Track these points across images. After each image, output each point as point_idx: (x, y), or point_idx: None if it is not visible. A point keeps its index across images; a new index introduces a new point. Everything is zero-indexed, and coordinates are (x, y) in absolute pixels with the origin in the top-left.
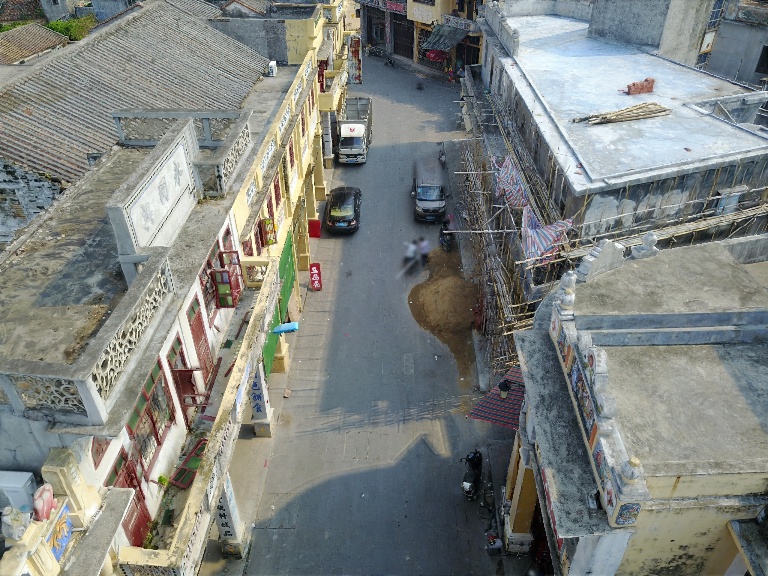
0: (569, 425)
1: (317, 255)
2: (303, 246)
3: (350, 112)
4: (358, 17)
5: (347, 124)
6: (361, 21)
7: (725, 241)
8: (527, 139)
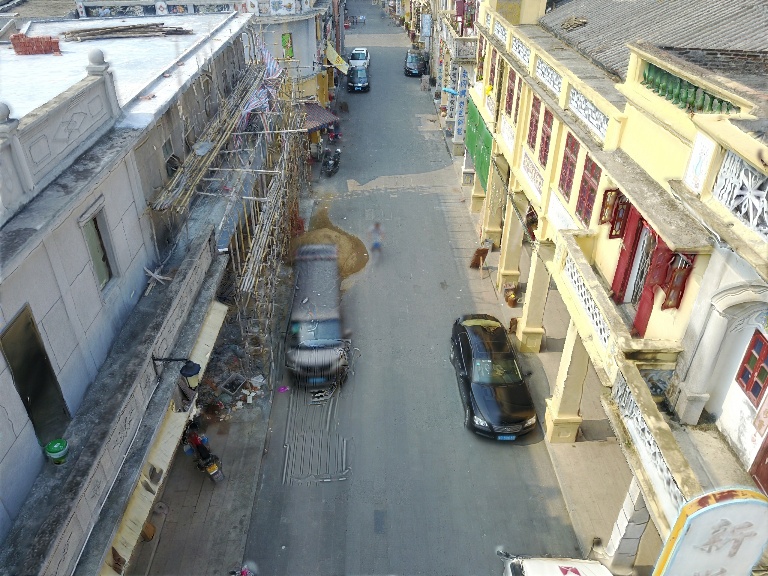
0: None
1: (498, 310)
2: None
3: None
4: None
5: None
6: None
7: None
8: None
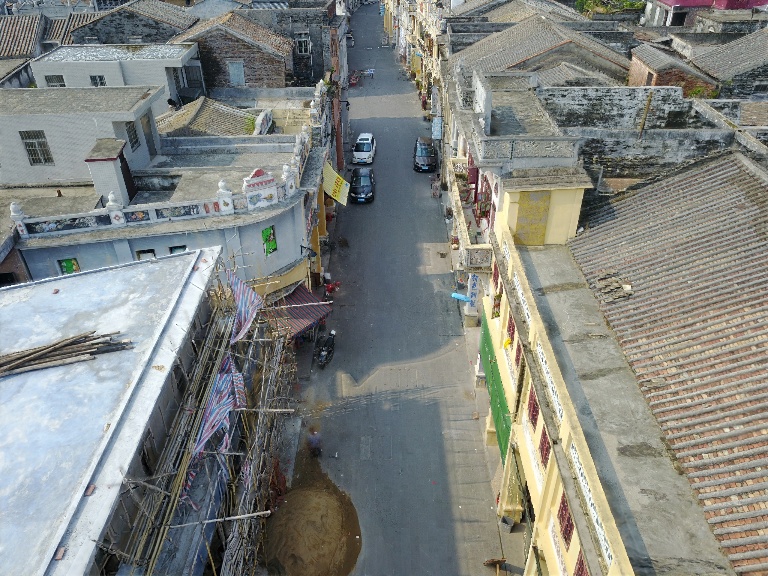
0: None
1: None
2: None
3: None
4: None
5: None
6: None
7: (164, 203)
8: None
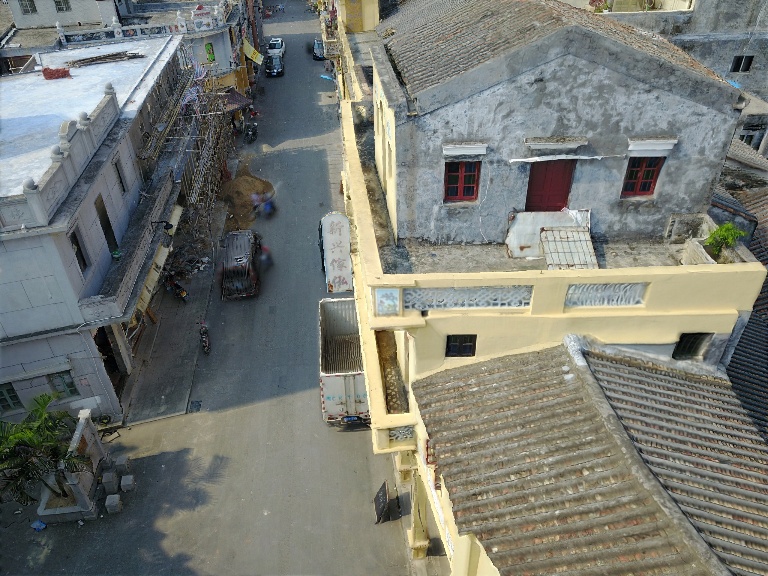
0: (231, 15)
1: None
2: None
3: None
4: None
5: None
6: None
7: (145, 25)
8: None
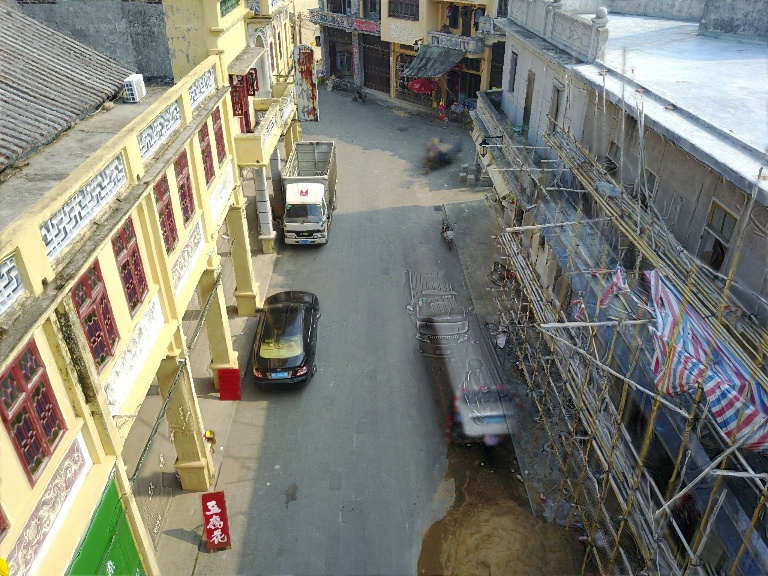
0: None
1: (231, 444)
2: (192, 448)
3: (303, 164)
4: (319, 46)
5: (296, 183)
6: (321, 48)
7: None
8: (678, 226)
